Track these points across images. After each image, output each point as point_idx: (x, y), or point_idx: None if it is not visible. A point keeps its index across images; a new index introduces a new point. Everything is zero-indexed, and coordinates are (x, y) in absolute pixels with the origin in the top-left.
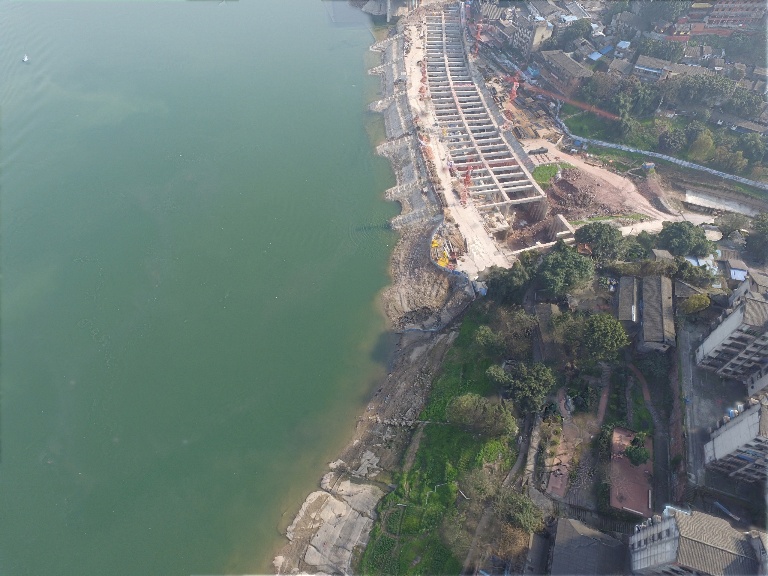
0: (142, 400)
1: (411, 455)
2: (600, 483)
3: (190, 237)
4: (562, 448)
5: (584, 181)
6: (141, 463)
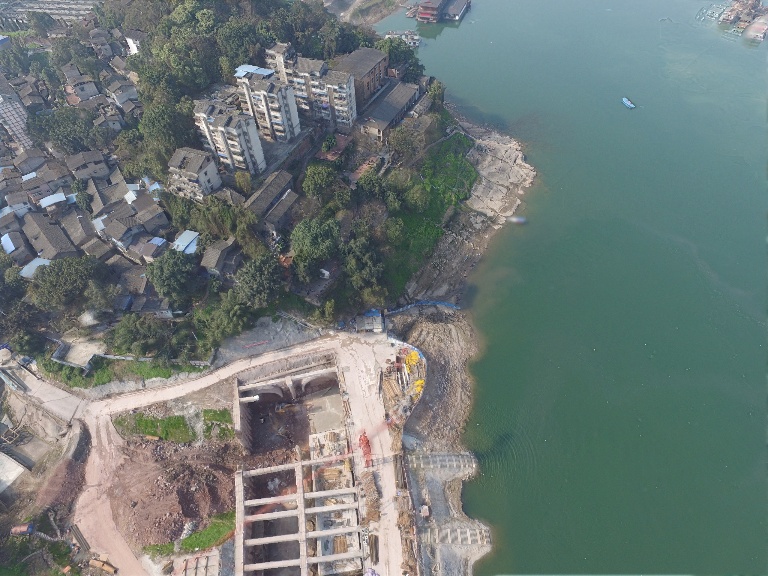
0: (664, 266)
1: (450, 211)
2: (353, 146)
3: (763, 452)
4: (363, 170)
5: (154, 511)
6: (633, 231)
